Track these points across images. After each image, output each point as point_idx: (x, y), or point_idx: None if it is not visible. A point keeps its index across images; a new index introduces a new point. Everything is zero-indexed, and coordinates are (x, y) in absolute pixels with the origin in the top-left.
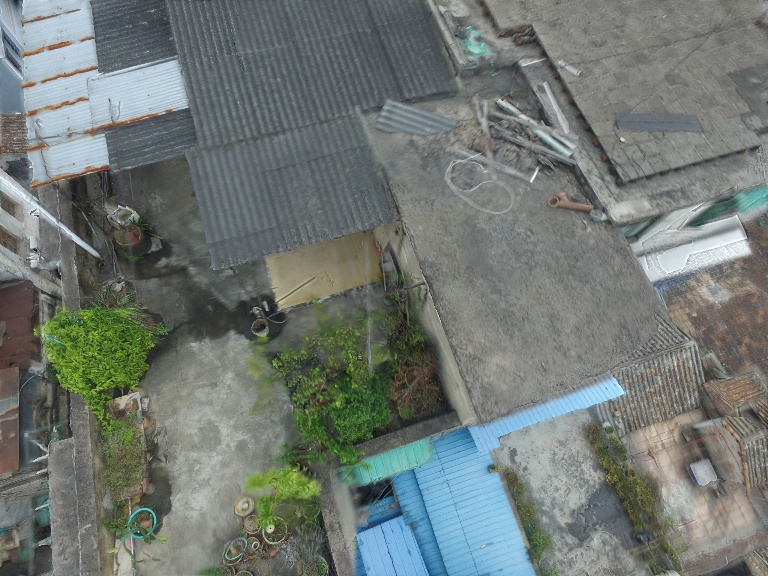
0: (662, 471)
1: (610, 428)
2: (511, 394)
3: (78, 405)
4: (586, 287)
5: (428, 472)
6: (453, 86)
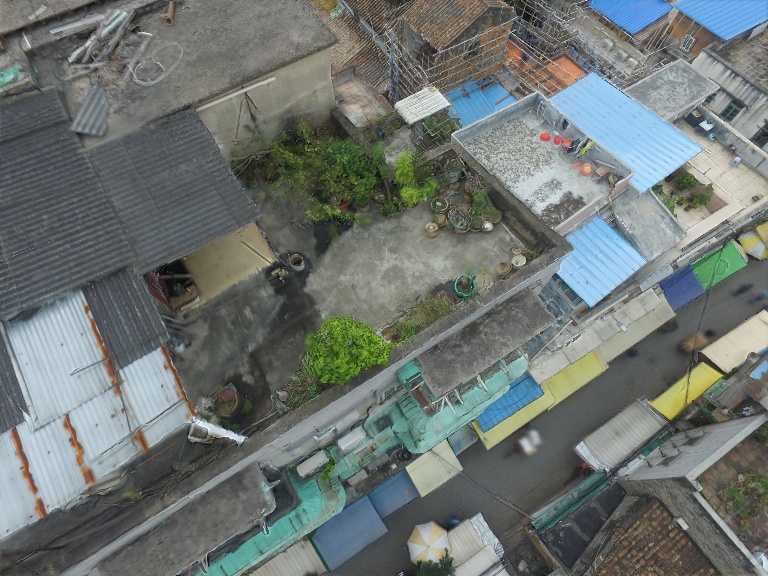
0: None
1: None
2: (316, 30)
3: (398, 354)
4: (235, 3)
5: None
6: (52, 91)
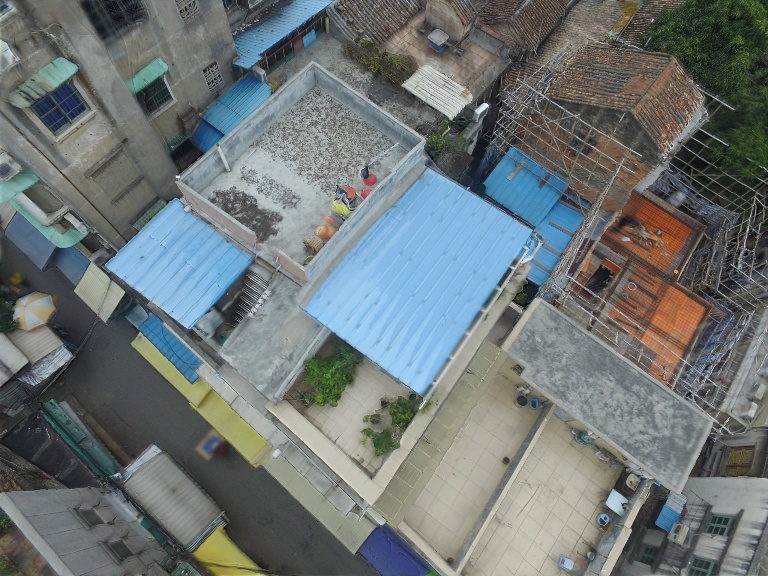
0: (416, 59)
1: (357, 38)
2: None
3: None
4: None
5: (226, 121)
6: None
